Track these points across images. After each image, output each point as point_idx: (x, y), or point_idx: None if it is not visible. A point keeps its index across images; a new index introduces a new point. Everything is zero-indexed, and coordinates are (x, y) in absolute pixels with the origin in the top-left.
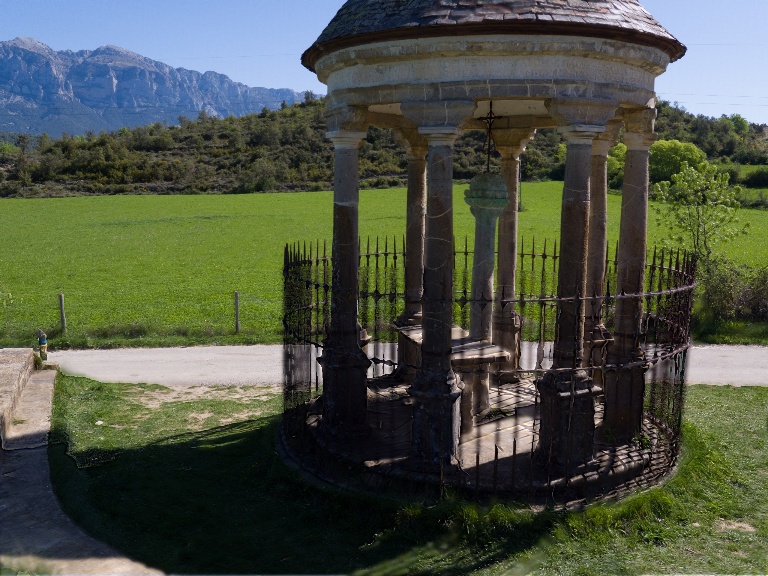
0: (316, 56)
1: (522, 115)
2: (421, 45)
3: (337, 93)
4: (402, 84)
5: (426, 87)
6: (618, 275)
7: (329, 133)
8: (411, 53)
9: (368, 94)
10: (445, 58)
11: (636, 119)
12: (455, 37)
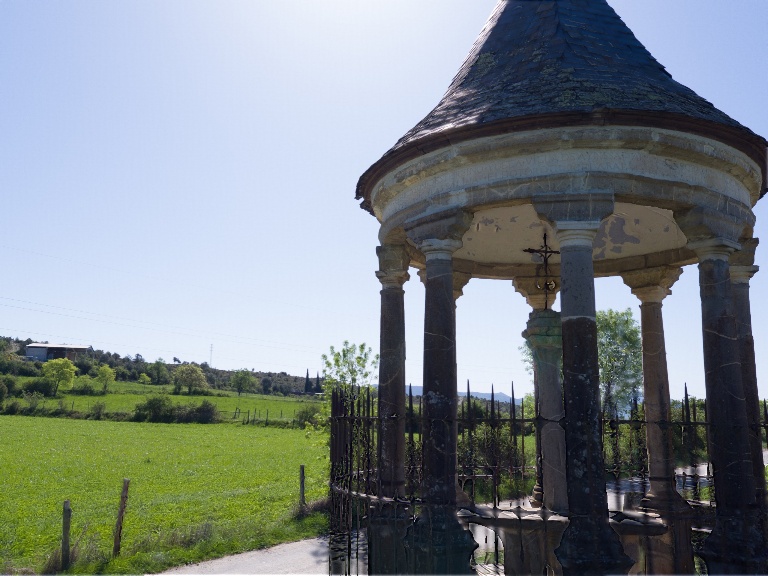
0: (561, 121)
1: (464, 259)
2: (729, 153)
3: (603, 175)
4: (703, 187)
5: (722, 197)
6: (659, 419)
7: (577, 222)
8: (719, 158)
9: (657, 187)
10: (727, 174)
11: (671, 275)
12: (748, 157)
